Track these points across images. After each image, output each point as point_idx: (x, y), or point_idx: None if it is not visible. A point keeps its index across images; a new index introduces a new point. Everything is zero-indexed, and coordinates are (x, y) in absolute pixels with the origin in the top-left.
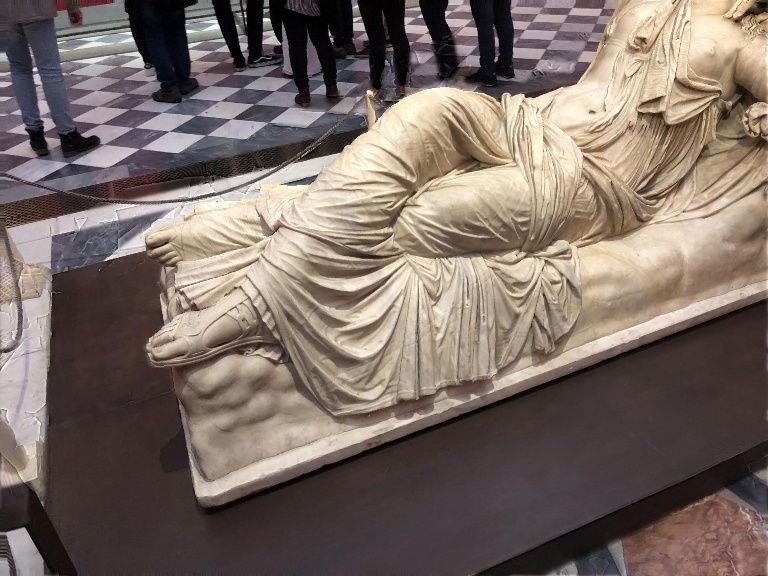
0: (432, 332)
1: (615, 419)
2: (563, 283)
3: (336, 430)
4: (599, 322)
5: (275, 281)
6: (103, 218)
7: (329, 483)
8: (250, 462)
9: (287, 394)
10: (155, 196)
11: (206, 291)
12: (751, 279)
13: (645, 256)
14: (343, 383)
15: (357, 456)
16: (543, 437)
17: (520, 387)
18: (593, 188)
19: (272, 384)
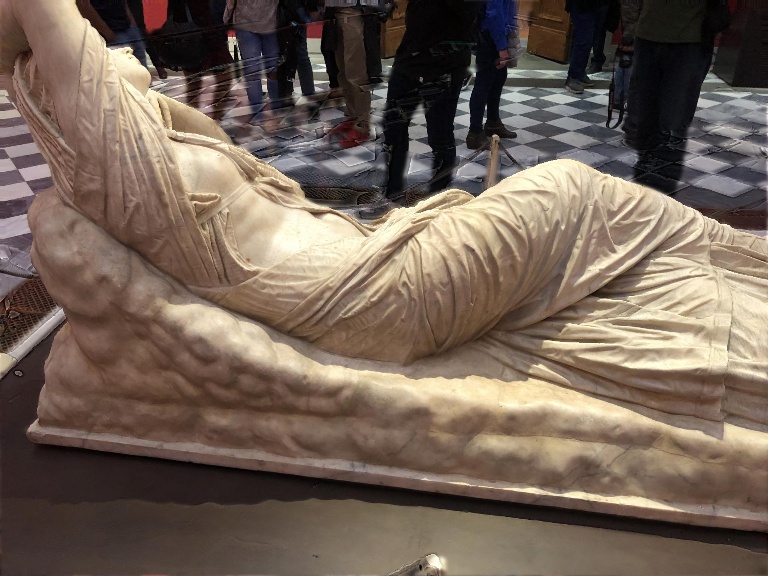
0: None
1: None
2: None
3: None
4: None
5: None
6: None
7: None
8: None
9: None
10: None
11: None
12: None
13: None
14: None
15: None
16: None
17: None
18: None
19: None
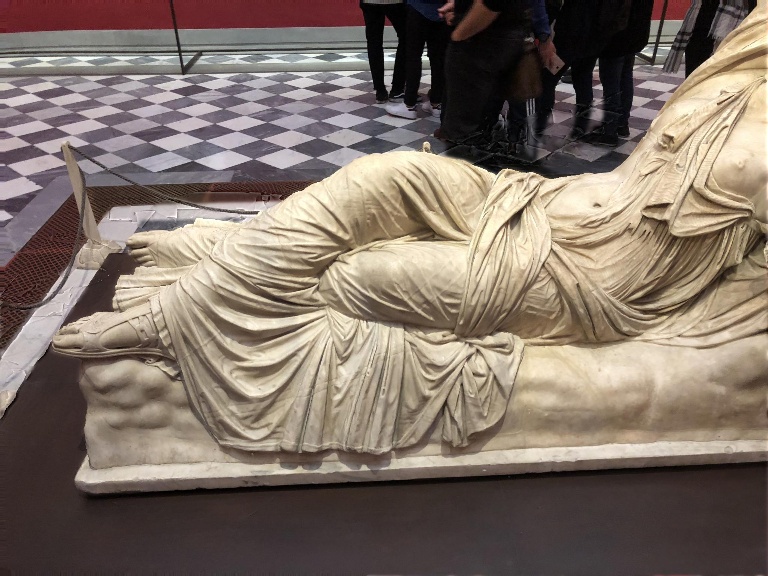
0: (331, 390)
1: (505, 539)
2: (489, 378)
3: (220, 458)
4: (532, 430)
5: (178, 303)
6: (171, 214)
7: (199, 506)
8: (133, 463)
9: (180, 410)
10: (214, 203)
11: (133, 297)
12: (747, 433)
13: (607, 373)
14: (232, 415)
15: (234, 490)
16: (417, 532)
17: (420, 473)
18: (556, 286)
19: (167, 397)
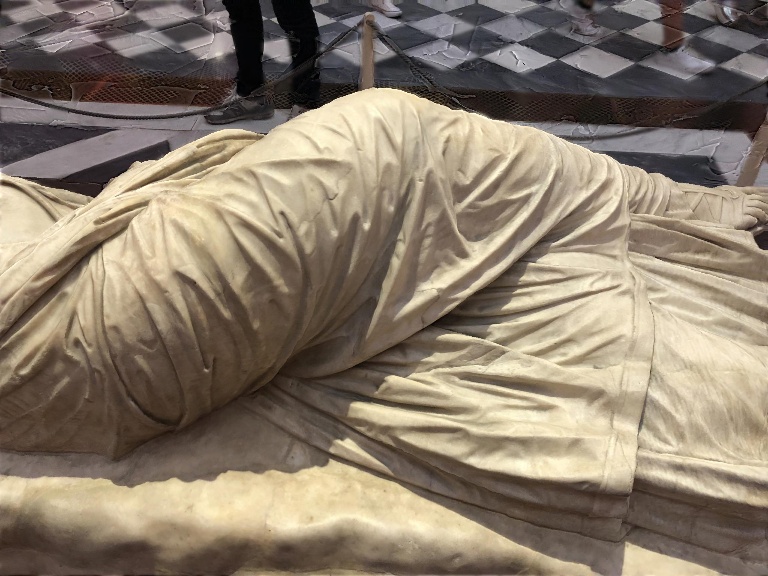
0: None
1: None
2: None
3: None
4: None
5: None
6: None
7: None
8: None
9: None
10: None
11: None
12: None
13: None
14: None
15: None
16: None
17: None
18: None
19: None
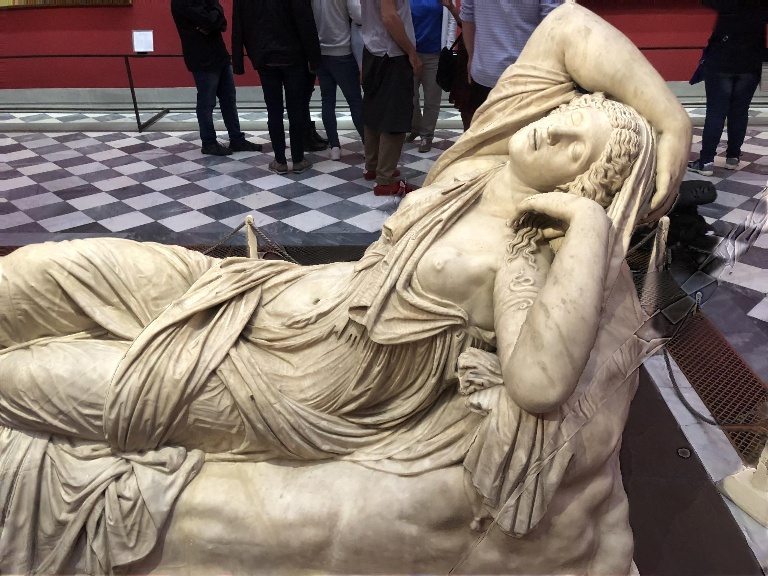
0: None
1: None
2: (137, 502)
3: None
4: (199, 564)
5: None
6: None
7: None
8: None
9: None
10: None
11: None
12: None
13: (287, 501)
14: None
15: None
16: None
17: None
18: (232, 397)
19: None
